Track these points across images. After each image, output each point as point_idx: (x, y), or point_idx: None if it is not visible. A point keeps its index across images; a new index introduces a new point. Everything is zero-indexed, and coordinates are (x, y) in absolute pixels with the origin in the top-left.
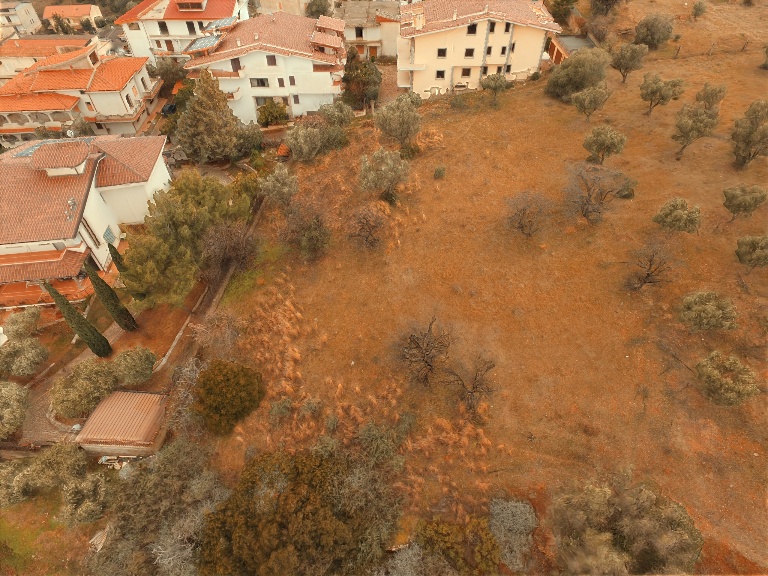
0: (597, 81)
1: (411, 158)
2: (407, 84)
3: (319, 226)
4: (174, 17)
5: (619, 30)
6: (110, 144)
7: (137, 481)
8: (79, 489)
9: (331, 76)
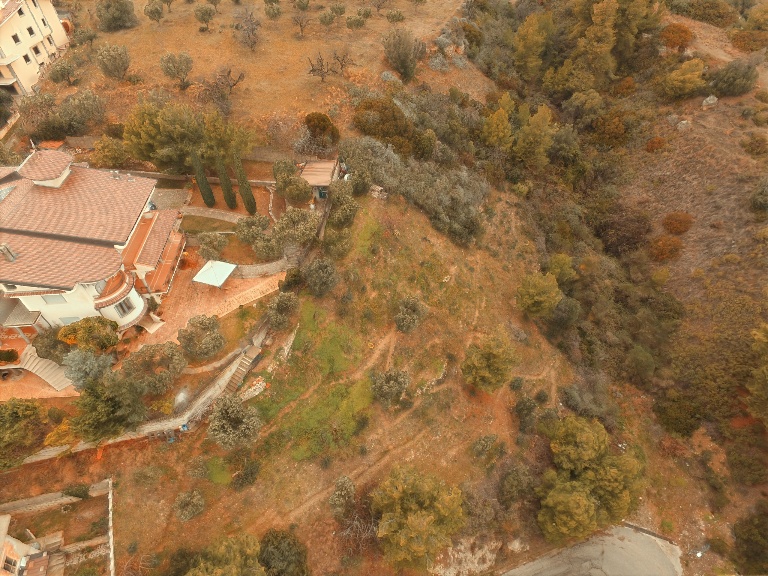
0: (131, 7)
1: None
2: (11, 79)
3: None
4: None
5: None
6: None
7: None
8: None
9: None
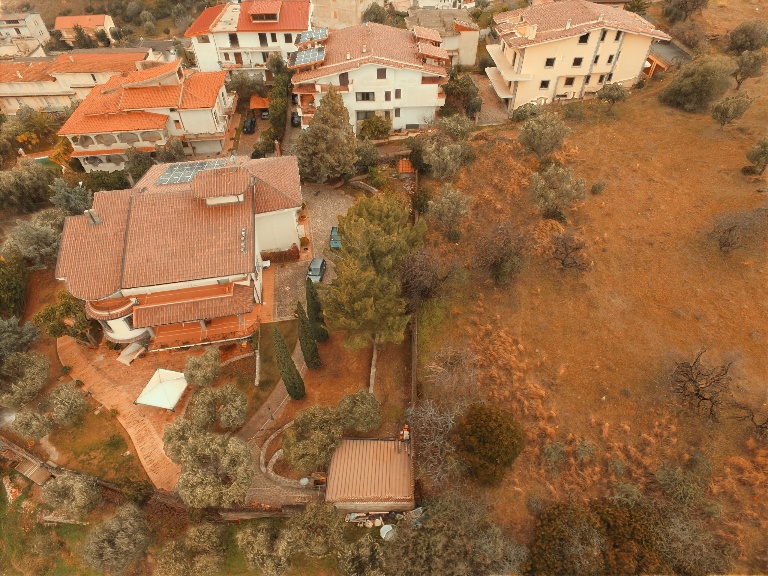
0: (723, 89)
1: None
2: (509, 94)
3: (518, 250)
4: (248, 29)
5: (706, 36)
6: (255, 167)
7: (416, 543)
8: (355, 556)
9: (438, 88)
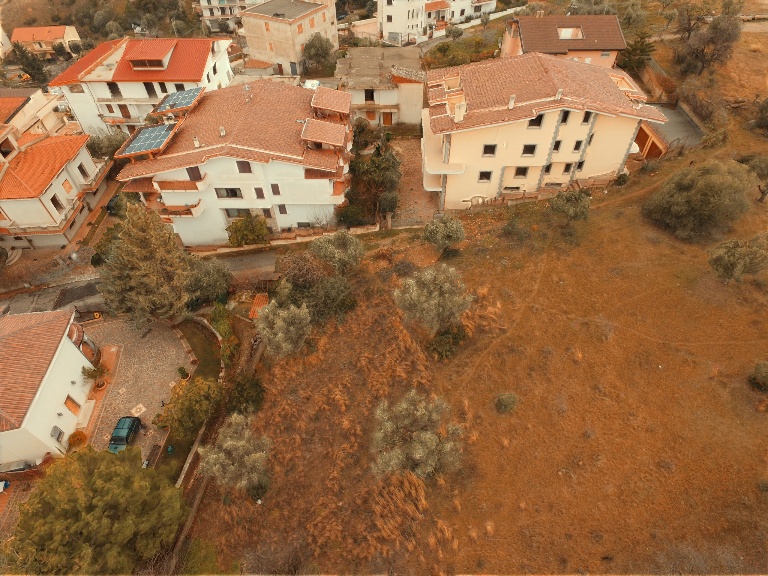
0: (735, 213)
1: (454, 353)
2: (437, 186)
3: None
4: (126, 78)
5: (726, 101)
6: None
7: None
8: None
9: (331, 183)
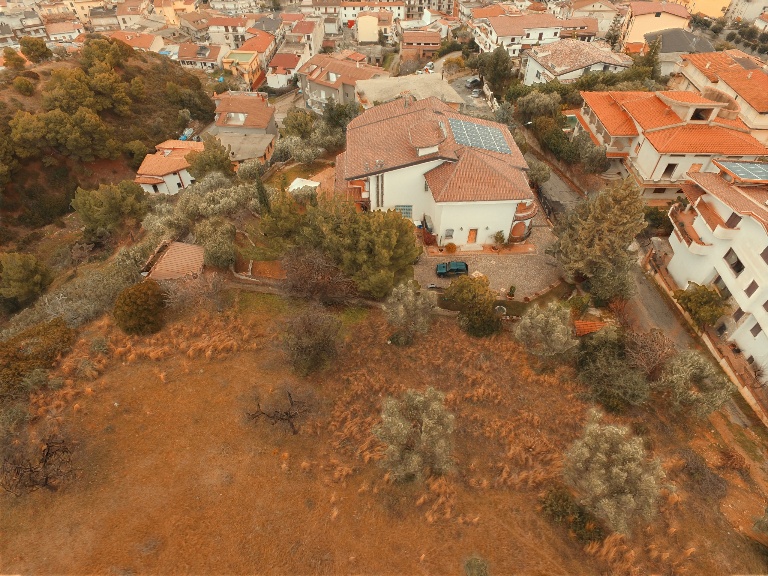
0: None
1: (552, 520)
2: None
3: None
4: None
5: None
6: (476, 160)
7: None
8: None
9: None
